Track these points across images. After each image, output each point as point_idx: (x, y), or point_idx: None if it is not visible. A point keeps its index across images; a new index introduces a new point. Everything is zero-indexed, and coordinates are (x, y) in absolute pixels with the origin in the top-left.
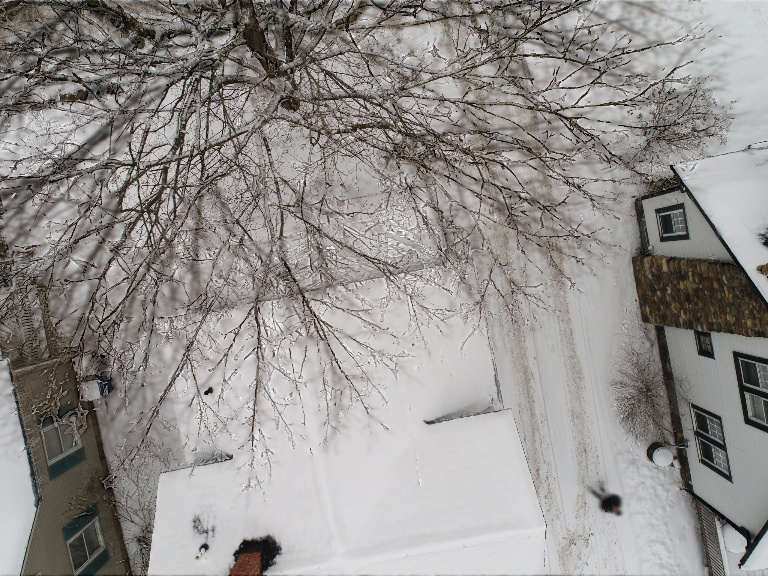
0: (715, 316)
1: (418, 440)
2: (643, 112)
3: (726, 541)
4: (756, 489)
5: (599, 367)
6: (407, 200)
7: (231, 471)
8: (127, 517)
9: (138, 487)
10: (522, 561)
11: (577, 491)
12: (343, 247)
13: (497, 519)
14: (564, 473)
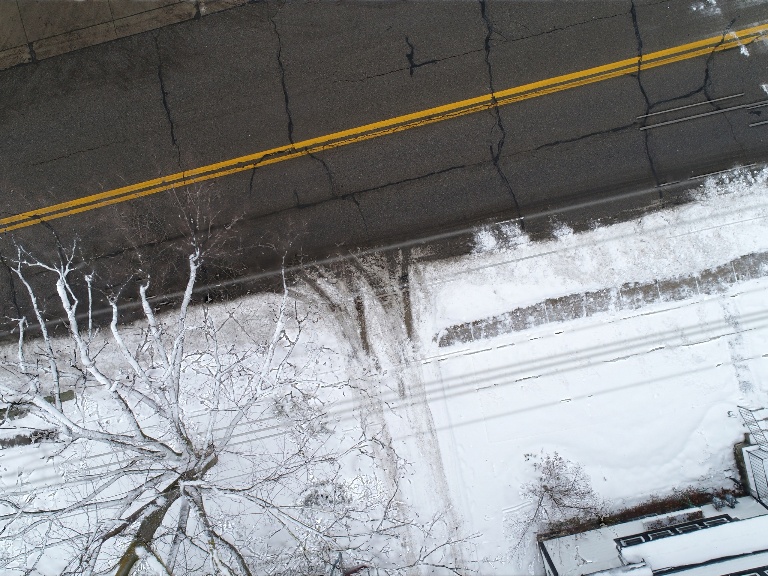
0: None
1: None
2: None
3: None
4: None
5: None
6: None
7: None
8: None
9: None
10: None
11: None
12: None
13: None
14: None
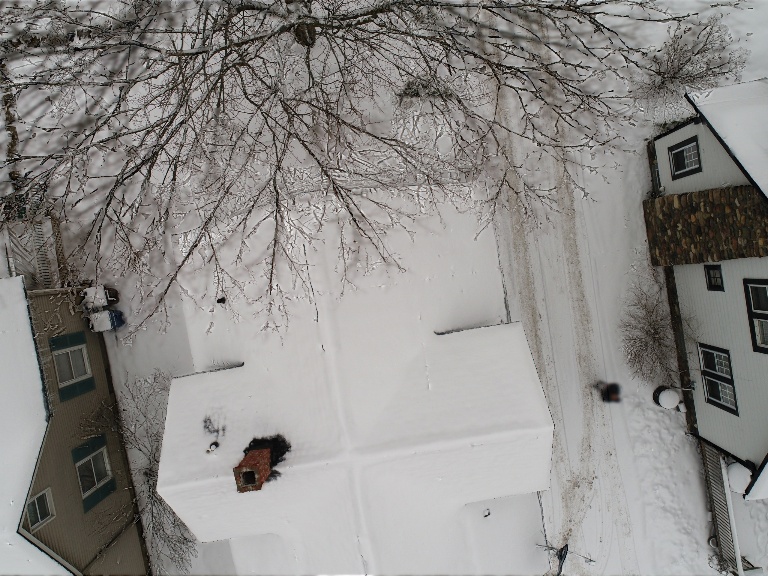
0: (726, 242)
1: (428, 348)
2: (658, 53)
3: (730, 480)
4: (763, 418)
5: (607, 309)
6: (424, 101)
7: (242, 376)
8: (135, 449)
9: (146, 418)
10: (529, 467)
11: (582, 434)
12: (361, 133)
13: (506, 420)
14: (570, 415)
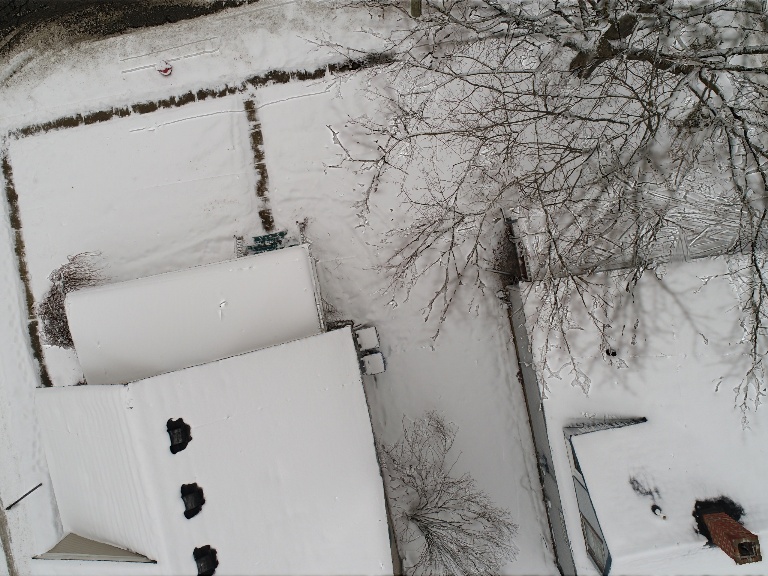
0: None
1: None
2: None
3: None
4: None
5: None
6: None
7: (654, 433)
8: None
9: (420, 462)
10: None
11: None
12: None
13: None
14: None
